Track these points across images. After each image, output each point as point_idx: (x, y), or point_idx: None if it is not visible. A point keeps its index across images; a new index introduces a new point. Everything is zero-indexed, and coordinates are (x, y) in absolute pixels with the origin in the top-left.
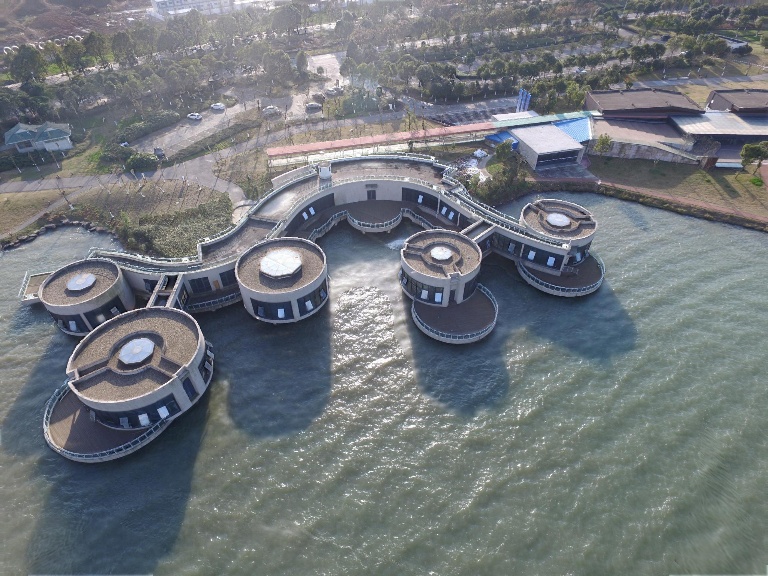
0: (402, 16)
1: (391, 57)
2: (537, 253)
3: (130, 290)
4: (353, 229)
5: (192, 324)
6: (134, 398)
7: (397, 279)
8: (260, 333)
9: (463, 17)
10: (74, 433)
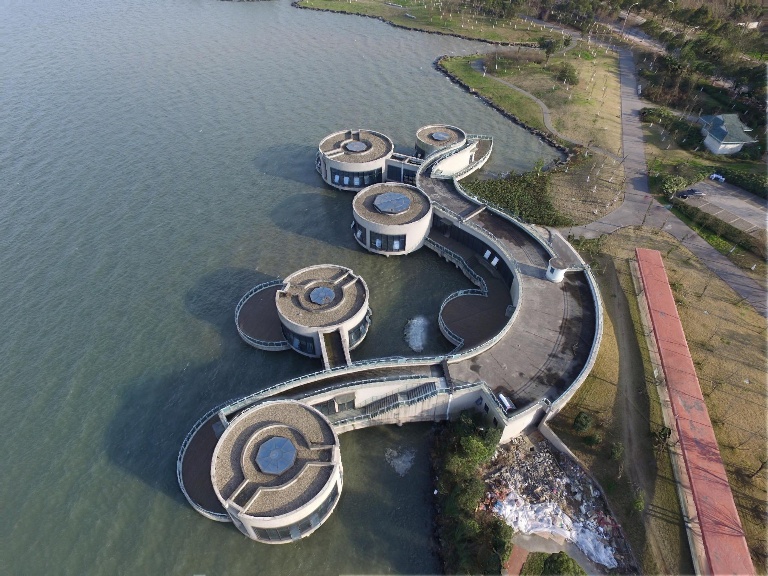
0: None
1: None
2: None
3: None
4: None
5: None
6: (321, 142)
7: None
8: None
9: None
10: None
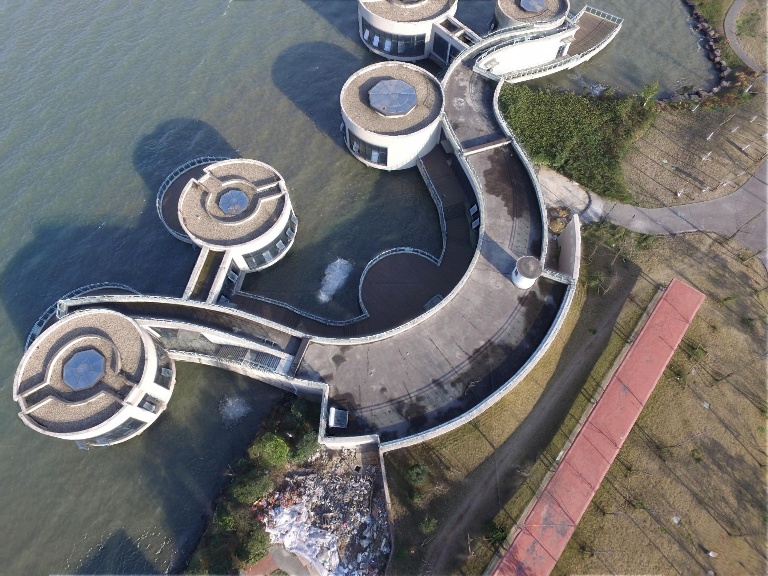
0: None
1: None
2: None
3: None
4: None
5: None
6: None
7: (297, 210)
8: None
9: None
10: None
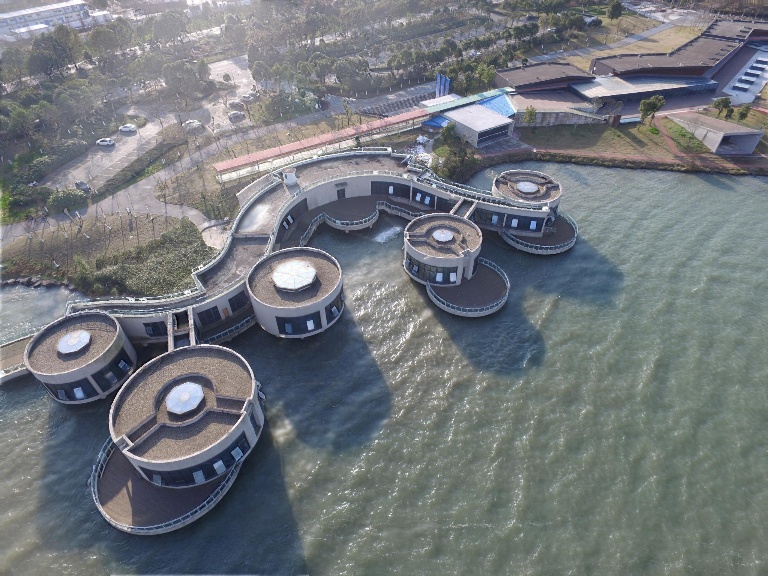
0: (290, 15)
1: (297, 57)
2: (519, 220)
3: (128, 339)
4: (336, 230)
5: (231, 356)
6: (211, 446)
7: (401, 269)
8: (290, 351)
9: (351, 12)
10: (137, 506)
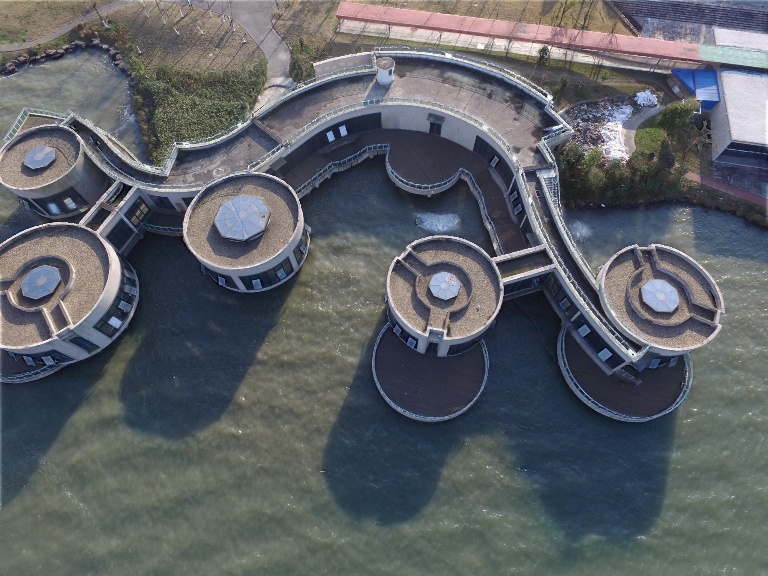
0: None
1: None
2: (592, 333)
3: (98, 177)
4: (386, 174)
5: None
6: (6, 347)
7: None
8: (203, 288)
9: None
10: None
